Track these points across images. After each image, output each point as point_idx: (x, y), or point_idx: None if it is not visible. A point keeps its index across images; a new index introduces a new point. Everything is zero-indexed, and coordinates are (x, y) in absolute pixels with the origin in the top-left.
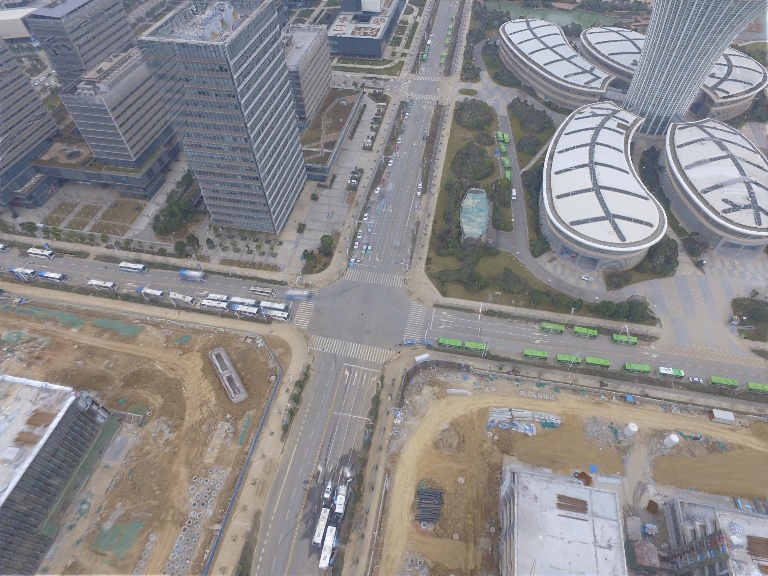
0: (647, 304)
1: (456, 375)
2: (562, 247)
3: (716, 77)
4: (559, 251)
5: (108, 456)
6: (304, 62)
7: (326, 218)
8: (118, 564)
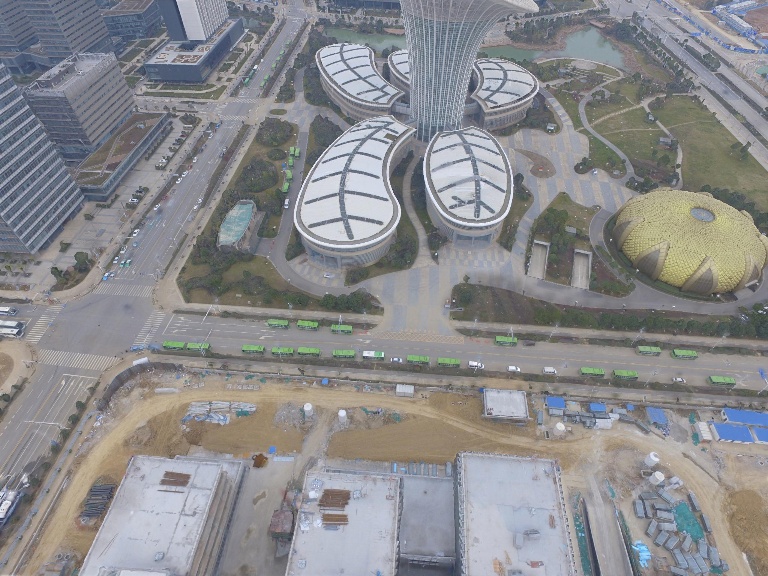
0: (367, 295)
1: (170, 375)
2: (309, 249)
3: (490, 90)
4: (309, 253)
5: None
6: (76, 88)
7: (95, 236)
8: None
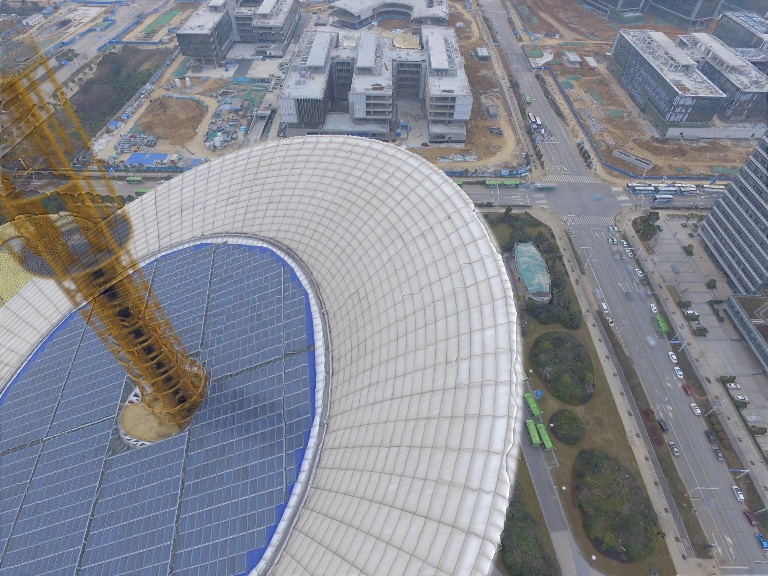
0: None
1: None
2: None
3: None
4: None
5: None
6: None
7: None
8: (609, 109)
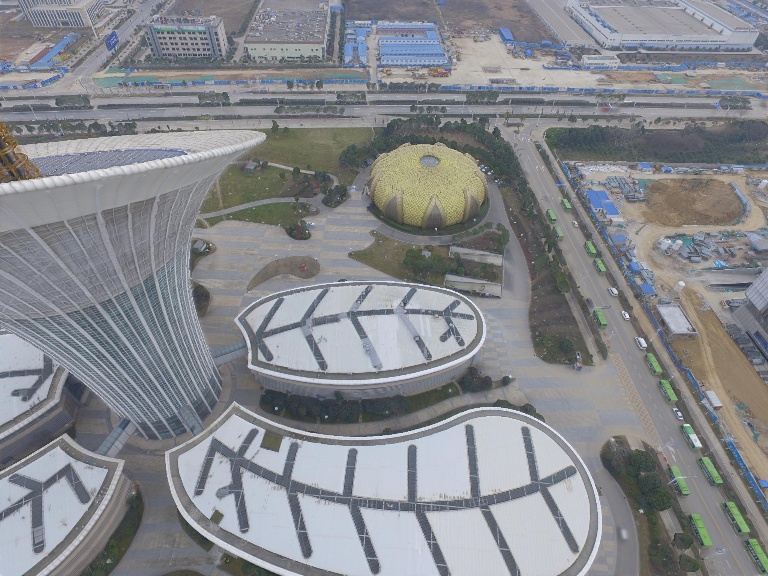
0: None
1: None
2: None
3: None
4: None
5: None
6: None
7: None
8: None
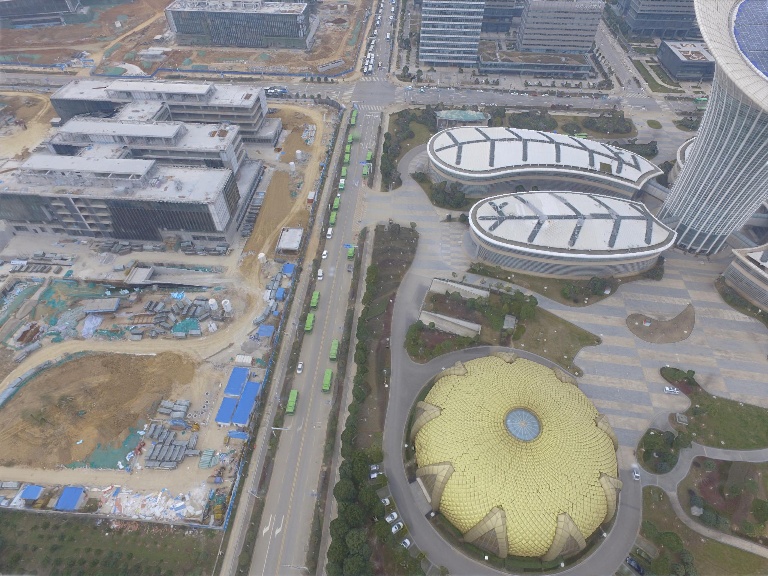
0: (391, 174)
1: (335, 117)
2: None
3: None
4: None
5: (293, 50)
6: (544, 5)
7: None
8: None
